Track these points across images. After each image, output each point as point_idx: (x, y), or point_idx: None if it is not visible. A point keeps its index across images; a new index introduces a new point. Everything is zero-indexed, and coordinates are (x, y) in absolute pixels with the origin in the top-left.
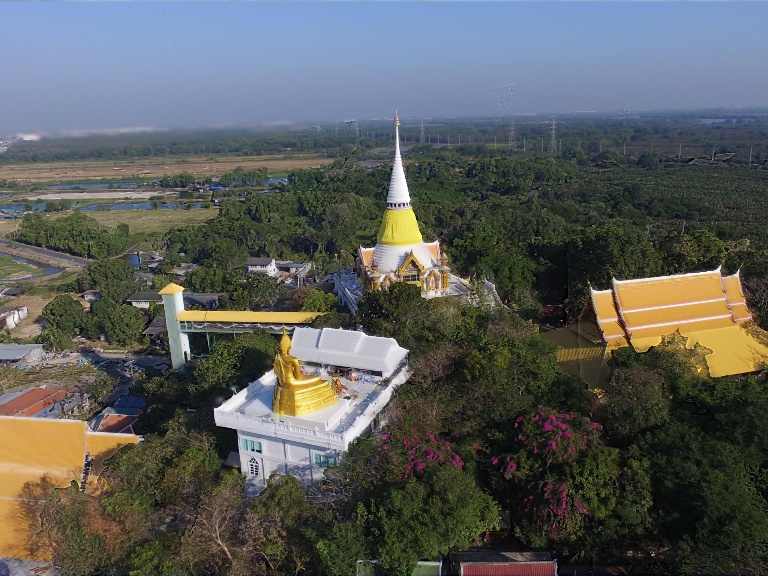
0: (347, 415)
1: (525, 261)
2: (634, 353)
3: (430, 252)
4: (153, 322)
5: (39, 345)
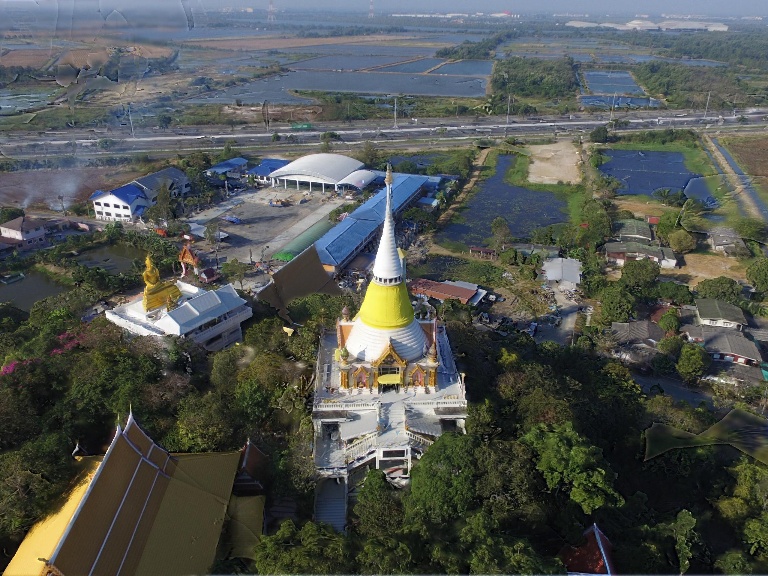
0: (139, 319)
1: (441, 487)
2: (45, 446)
3: (382, 348)
4: (636, 322)
5: (575, 281)
